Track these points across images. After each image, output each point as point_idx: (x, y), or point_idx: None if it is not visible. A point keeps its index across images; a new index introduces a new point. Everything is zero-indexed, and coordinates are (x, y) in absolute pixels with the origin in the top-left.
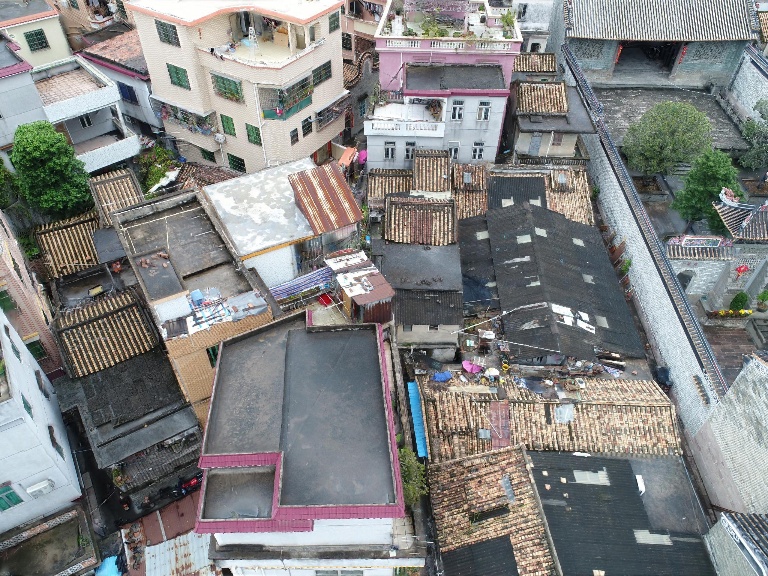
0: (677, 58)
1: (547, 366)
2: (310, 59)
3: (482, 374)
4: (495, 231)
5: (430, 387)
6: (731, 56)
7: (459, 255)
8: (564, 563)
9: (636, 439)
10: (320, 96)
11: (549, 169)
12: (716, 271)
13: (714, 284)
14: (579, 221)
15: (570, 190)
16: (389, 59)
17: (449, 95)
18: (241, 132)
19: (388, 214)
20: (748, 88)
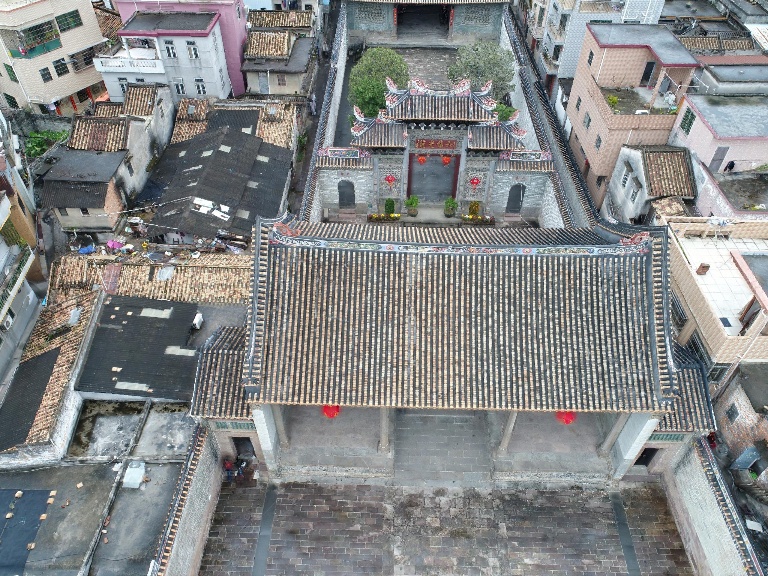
0: (450, 20)
1: (180, 245)
2: (48, 6)
3: (120, 248)
4: (191, 149)
5: None
6: (497, 19)
7: (122, 158)
8: (92, 362)
9: (216, 292)
10: (72, 41)
11: (263, 103)
12: (368, 180)
13: (373, 193)
14: (279, 145)
15: (277, 120)
16: (126, 8)
17: (156, 35)
18: (4, 72)
19: (71, 126)
20: (503, 46)
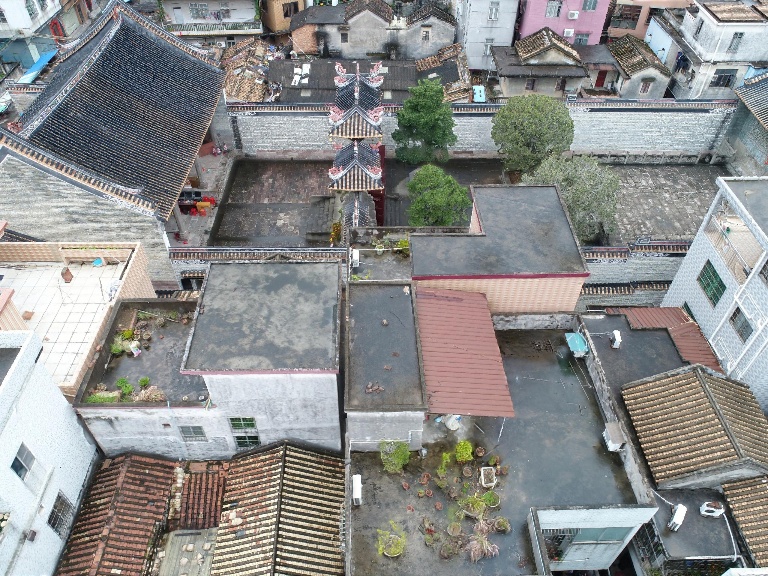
0: None
1: None
2: None
3: None
4: (389, 61)
5: (265, 43)
6: None
7: (335, 23)
8: None
9: None
10: None
11: None
12: None
13: None
14: None
15: None
16: None
17: None
18: None
19: None
20: None
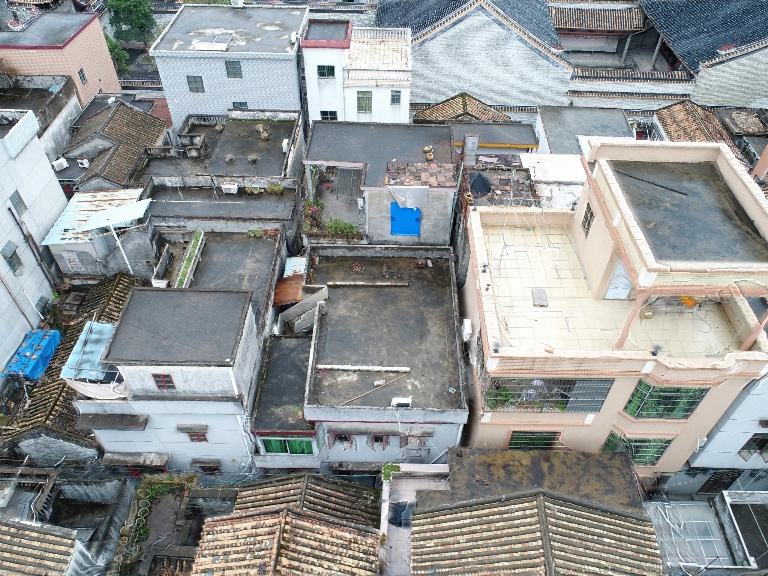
0: None
1: None
2: None
3: None
4: None
5: None
6: None
7: None
8: None
9: None
10: None
11: None
12: None
13: None
14: None
15: None
16: None
17: None
18: None
19: None
20: None
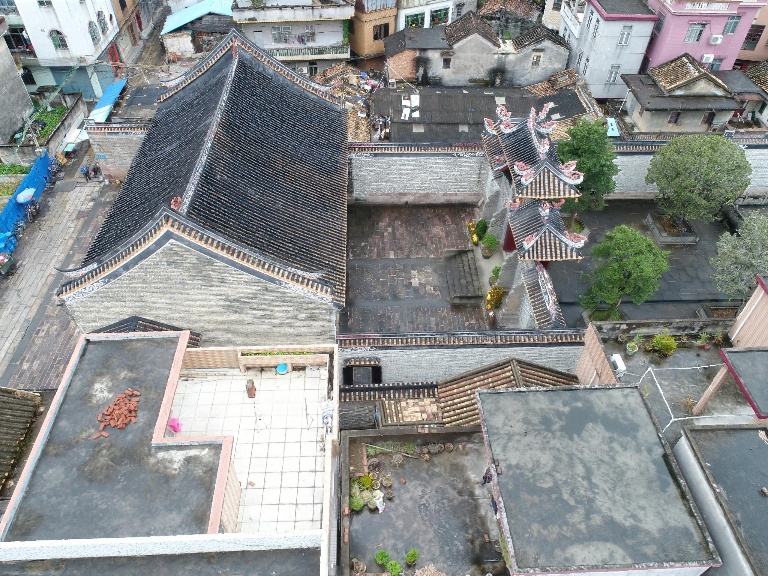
0: None
1: None
2: None
3: None
4: None
5: (355, 70)
6: None
7: (439, 48)
8: None
9: None
10: None
11: (594, 108)
12: None
13: None
14: None
15: None
16: None
17: None
18: None
19: None
20: None
